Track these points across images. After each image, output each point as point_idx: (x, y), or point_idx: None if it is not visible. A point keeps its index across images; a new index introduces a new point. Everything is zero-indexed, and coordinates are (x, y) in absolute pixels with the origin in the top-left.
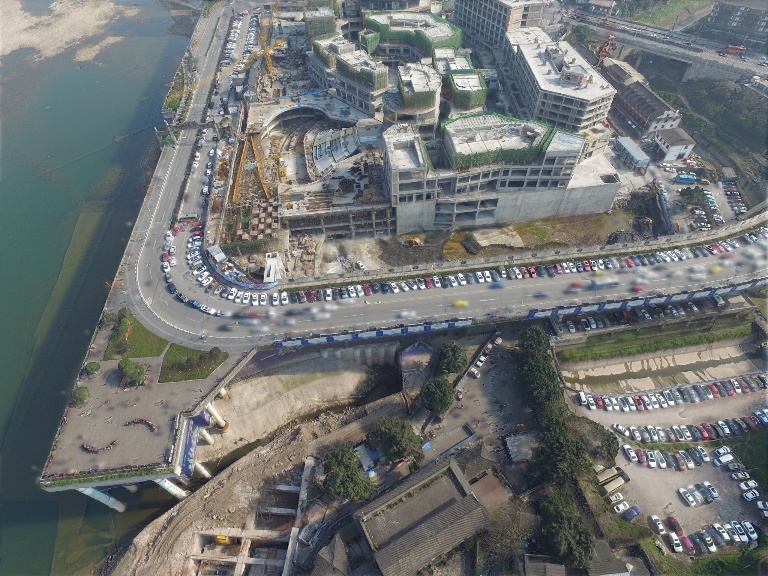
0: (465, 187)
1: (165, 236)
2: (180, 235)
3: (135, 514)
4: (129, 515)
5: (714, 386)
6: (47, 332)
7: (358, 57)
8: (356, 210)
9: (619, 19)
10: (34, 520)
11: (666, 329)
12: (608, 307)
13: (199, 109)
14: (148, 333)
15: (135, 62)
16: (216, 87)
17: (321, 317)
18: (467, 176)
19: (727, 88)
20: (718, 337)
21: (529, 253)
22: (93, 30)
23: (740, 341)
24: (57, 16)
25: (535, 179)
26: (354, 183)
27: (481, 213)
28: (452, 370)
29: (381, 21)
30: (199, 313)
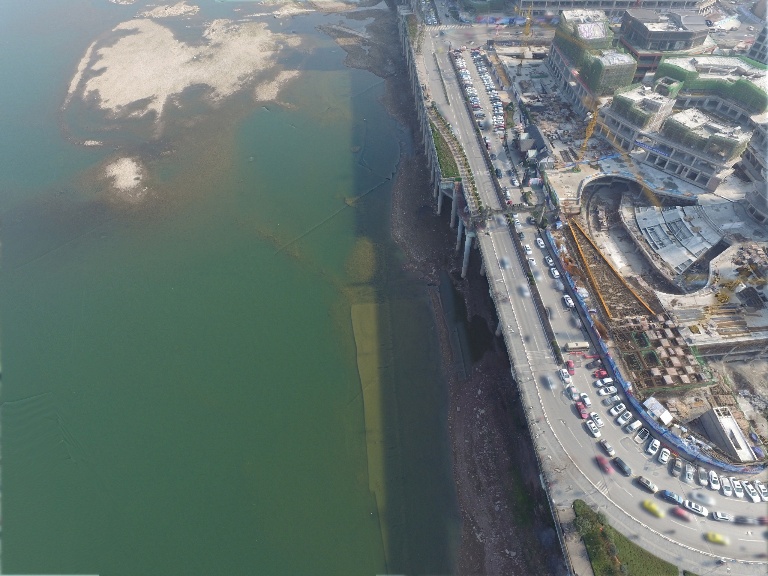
0: None
1: (558, 374)
2: (577, 373)
3: None
4: None
5: None
6: (385, 484)
7: (695, 118)
8: None
9: None
10: None
11: None
12: None
13: (485, 178)
14: (640, 550)
15: (325, 102)
16: (489, 148)
17: None
18: None
19: None
20: None
21: None
22: (262, 63)
23: None
24: (216, 46)
25: None
26: (757, 294)
27: None
28: None
29: (685, 67)
30: (685, 513)
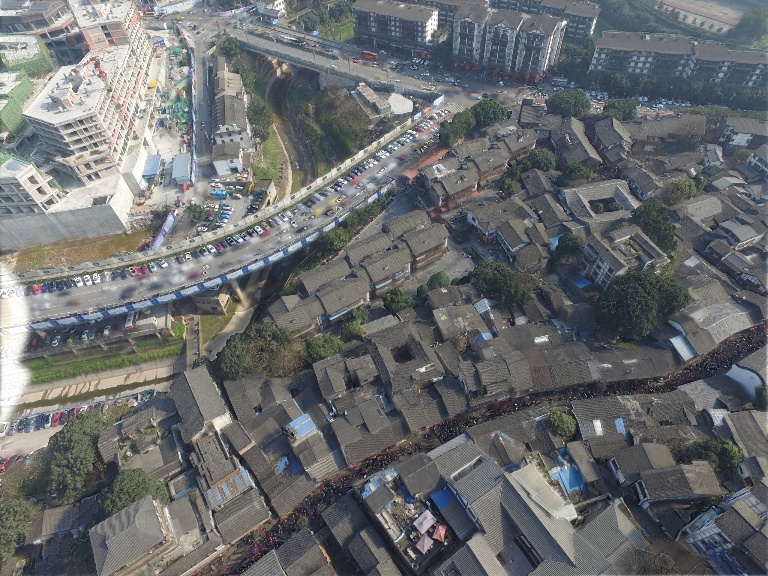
0: None
1: None
2: None
3: None
4: None
5: (57, 414)
6: None
7: None
8: None
9: (286, 28)
10: None
11: (81, 354)
12: None
13: None
14: None
15: None
16: None
17: None
18: None
19: (336, 96)
20: (143, 359)
21: None
22: None
23: (172, 361)
24: None
25: (3, 206)
26: None
27: None
28: None
29: None
30: None
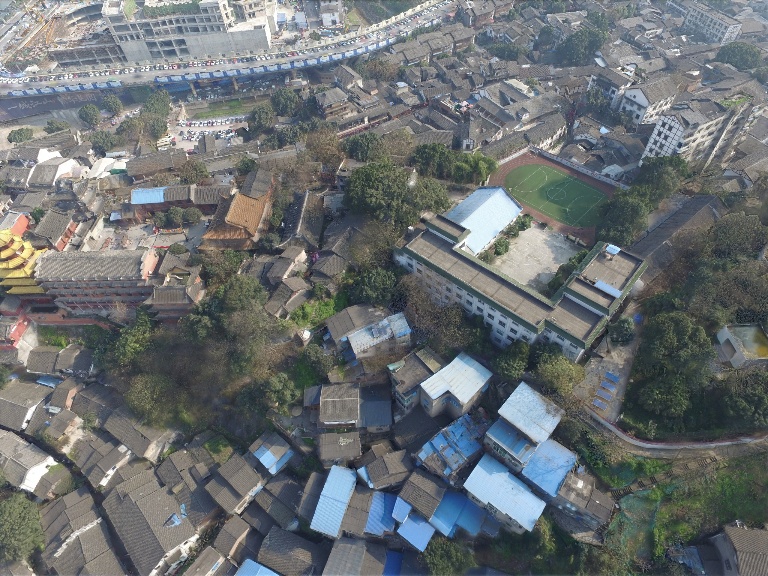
0: (160, 31)
1: None
2: None
3: None
4: None
5: None
6: None
7: None
8: (95, 47)
9: None
10: None
11: (258, 100)
12: (203, 77)
13: None
14: None
15: None
16: None
17: (43, 86)
18: (156, 22)
19: None
20: None
21: None
22: None
23: None
24: None
25: (204, 25)
26: (101, 35)
27: (183, 53)
28: (107, 108)
29: None
30: None
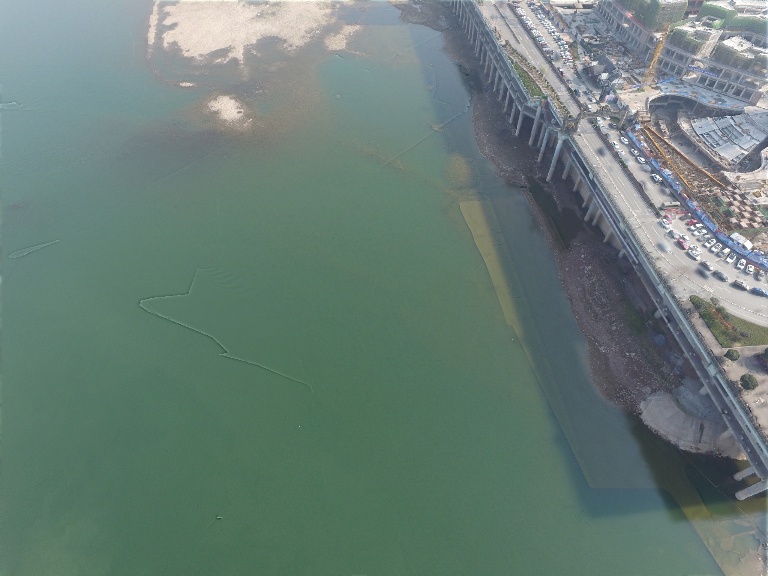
0: None
1: (659, 224)
2: (674, 223)
3: (756, 502)
4: (751, 503)
5: None
6: (519, 320)
7: (741, 43)
8: None
9: None
10: (656, 507)
11: None
12: None
13: (566, 97)
14: (744, 321)
15: (392, 51)
16: (564, 75)
17: None
18: None
19: None
20: None
21: None
22: (323, 19)
23: None
24: (275, 5)
25: None
26: None
27: None
28: None
29: (725, 7)
30: None
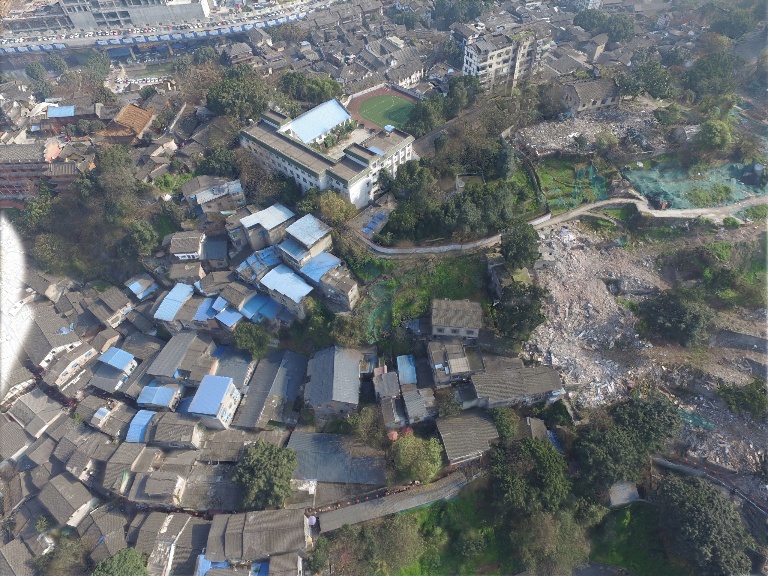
0: (105, 3)
1: None
2: None
3: None
4: None
5: None
6: None
7: None
8: (46, 17)
9: None
10: None
11: None
12: (139, 41)
13: None
14: None
15: None
16: None
17: None
18: None
19: None
20: None
21: (117, 25)
22: None
23: None
24: None
25: None
26: None
27: None
28: (52, 67)
29: None
30: None
